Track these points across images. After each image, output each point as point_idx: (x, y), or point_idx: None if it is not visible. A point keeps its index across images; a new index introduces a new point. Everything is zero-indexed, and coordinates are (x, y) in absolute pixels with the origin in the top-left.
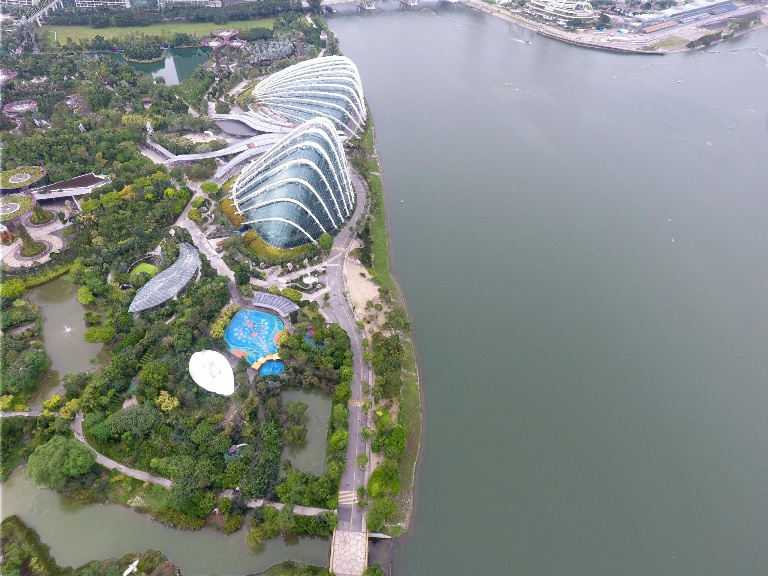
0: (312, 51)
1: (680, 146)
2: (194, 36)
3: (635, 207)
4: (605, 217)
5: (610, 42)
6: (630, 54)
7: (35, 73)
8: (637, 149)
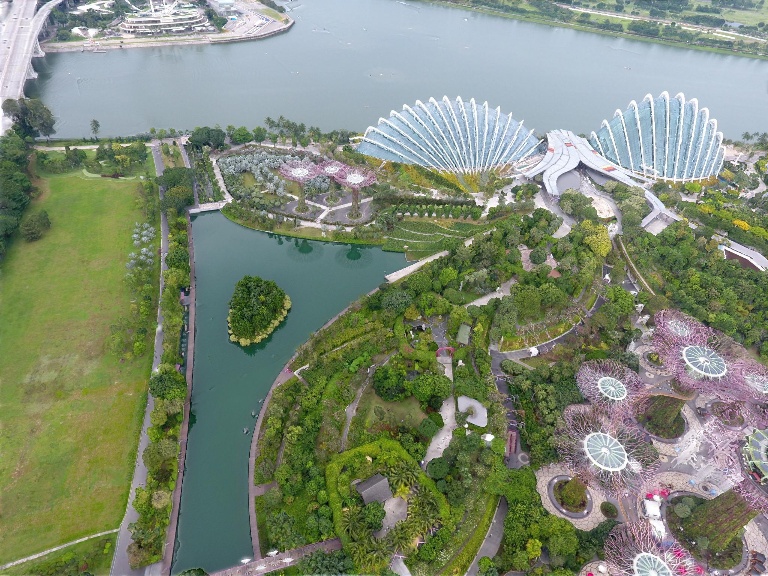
0: (303, 139)
1: (473, 54)
2: (138, 256)
3: (561, 79)
4: (579, 87)
5: (264, 27)
6: (289, 30)
7: (423, 442)
8: (485, 63)
